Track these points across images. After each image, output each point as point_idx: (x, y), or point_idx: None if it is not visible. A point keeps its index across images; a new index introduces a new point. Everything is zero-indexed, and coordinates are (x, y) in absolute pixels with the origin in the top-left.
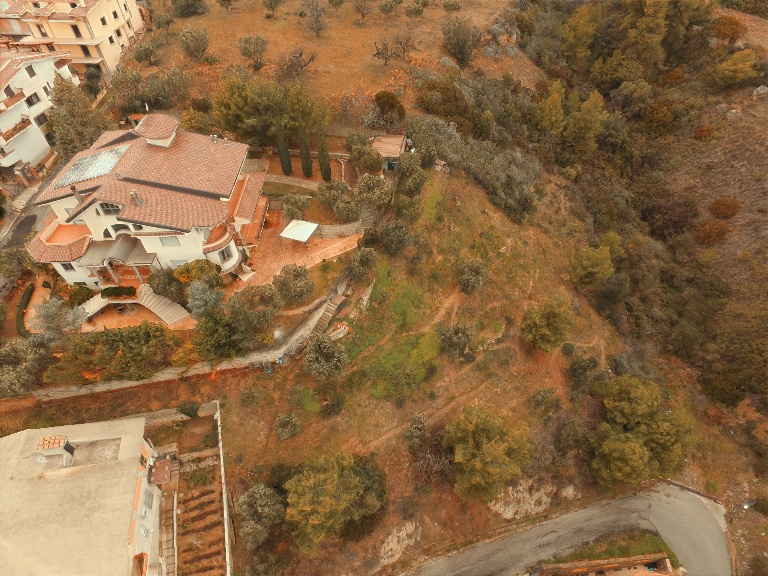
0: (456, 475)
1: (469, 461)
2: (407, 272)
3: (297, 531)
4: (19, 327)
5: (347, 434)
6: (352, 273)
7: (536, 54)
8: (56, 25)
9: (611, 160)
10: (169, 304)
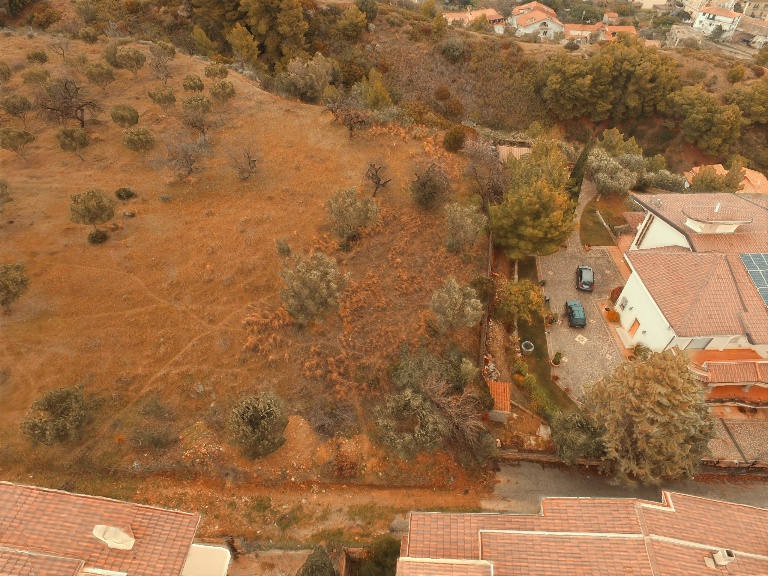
0: None
1: None
2: None
3: None
4: None
5: None
6: (682, 187)
7: None
8: None
9: None
10: None
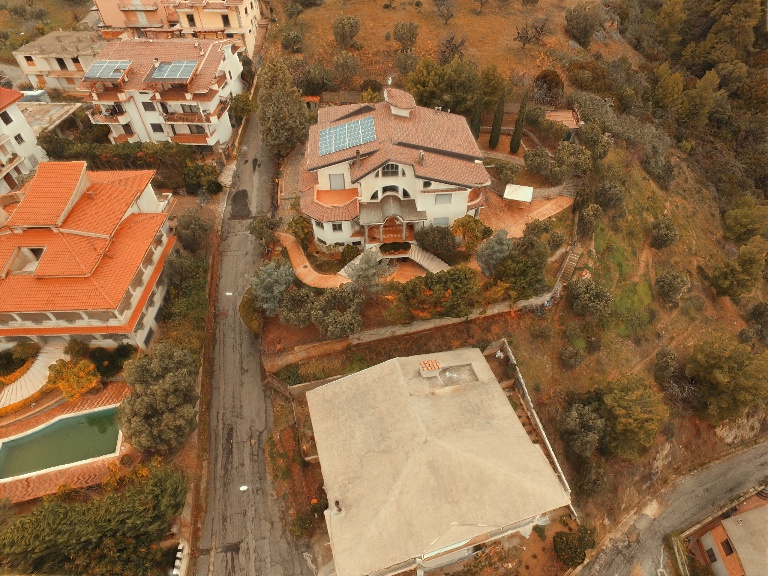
0: (705, 399)
1: (729, 383)
2: (612, 229)
3: (615, 442)
4: (300, 283)
5: (609, 367)
6: (585, 227)
7: (635, 39)
8: (207, 15)
9: (717, 135)
10: (432, 258)
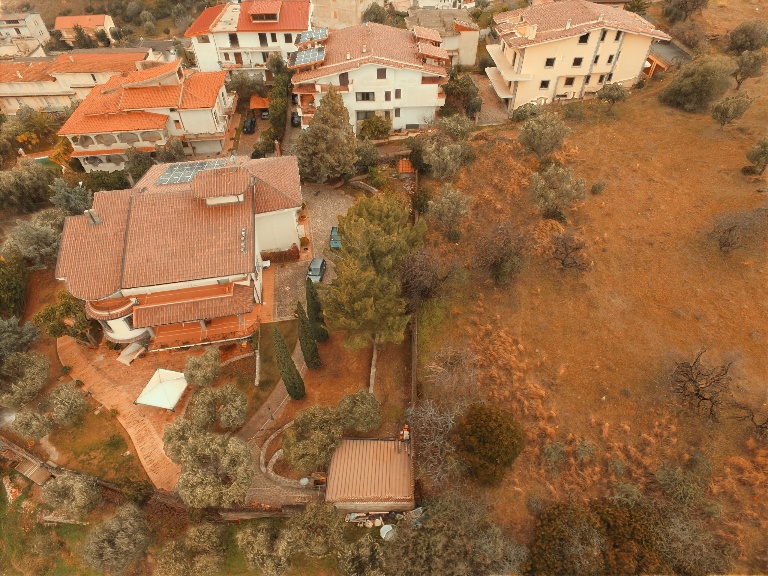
0: None
1: None
2: None
3: None
4: None
5: None
6: None
7: None
8: None
9: None
10: None
